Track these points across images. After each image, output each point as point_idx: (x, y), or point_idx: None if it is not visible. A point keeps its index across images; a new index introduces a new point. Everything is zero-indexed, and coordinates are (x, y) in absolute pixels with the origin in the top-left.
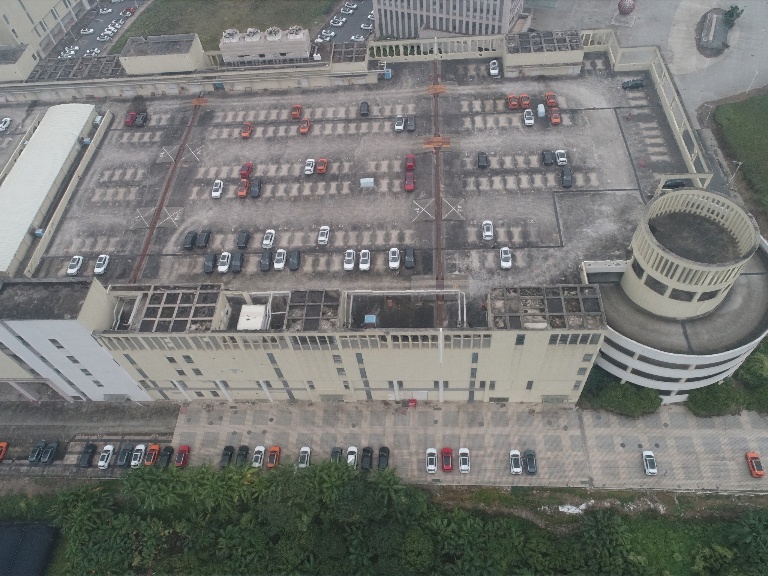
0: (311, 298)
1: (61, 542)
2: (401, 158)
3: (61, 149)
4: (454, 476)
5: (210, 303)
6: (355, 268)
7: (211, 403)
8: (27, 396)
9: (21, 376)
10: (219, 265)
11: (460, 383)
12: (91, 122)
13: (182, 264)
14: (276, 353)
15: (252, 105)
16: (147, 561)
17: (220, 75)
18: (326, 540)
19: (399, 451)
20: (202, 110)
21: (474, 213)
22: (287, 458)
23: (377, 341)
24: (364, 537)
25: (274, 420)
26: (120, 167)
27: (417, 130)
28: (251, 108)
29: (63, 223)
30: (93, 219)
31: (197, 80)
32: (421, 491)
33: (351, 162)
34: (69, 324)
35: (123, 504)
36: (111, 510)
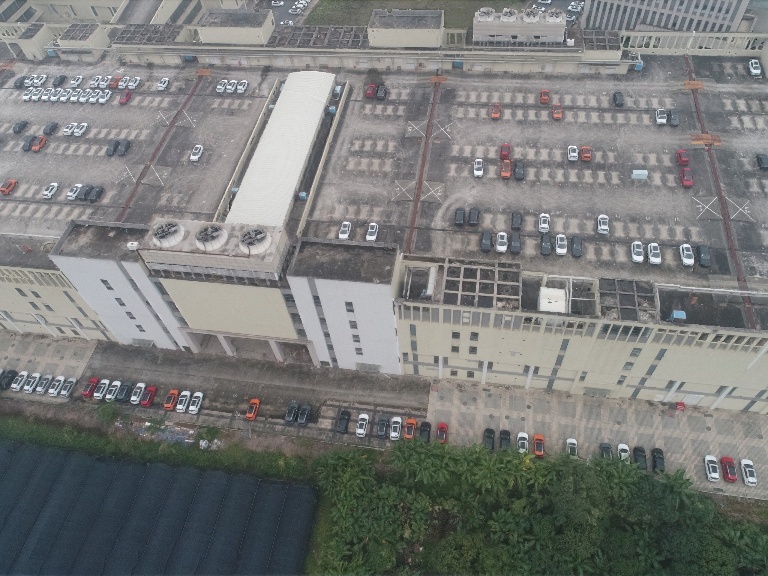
0: (621, 287)
1: (322, 505)
2: (669, 152)
3: (312, 115)
4: (738, 487)
5: (513, 282)
6: (643, 261)
7: (462, 383)
8: (276, 356)
9: (285, 336)
10: (498, 244)
11: (748, 391)
12: (332, 91)
13: (455, 240)
14: (574, 340)
15: (494, 87)
16: (417, 535)
17: (466, 54)
18: (616, 537)
19: (672, 454)
20: (443, 88)
21: (764, 216)
22: (551, 448)
23: (695, 338)
24: (651, 539)
25: (532, 408)
26: (369, 138)
27: (680, 125)
28: (494, 89)
29: (322, 188)
30: (352, 187)
31: (439, 57)
32: (705, 499)
33: (615, 152)
34: (379, 288)
35: (382, 474)
36: (374, 479)
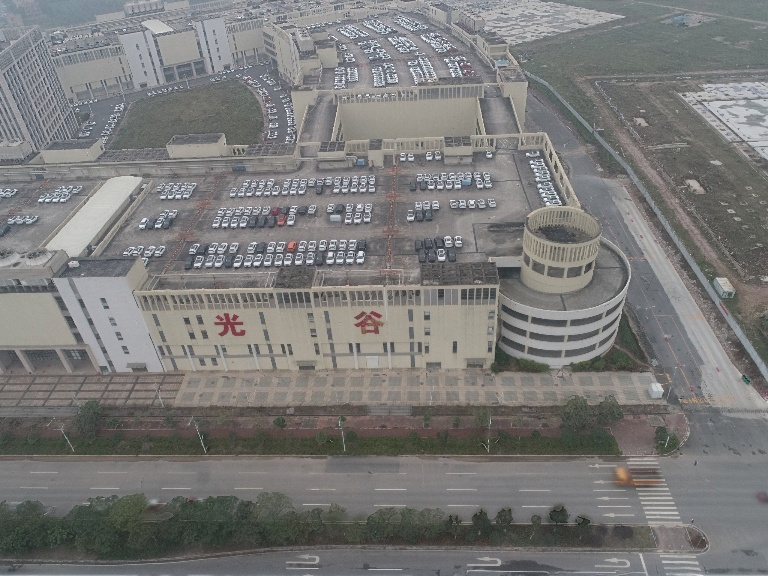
0: None
1: None
2: None
3: (156, 30)
4: None
5: (67, 27)
6: None
7: None
8: None
9: None
10: None
11: None
12: None
13: None
14: None
15: None
16: None
17: None
18: None
19: None
20: None
21: None
22: None
23: None
24: None
25: None
26: None
27: None
28: None
29: None
30: None
31: None
32: None
33: None
34: None
35: None
36: None
